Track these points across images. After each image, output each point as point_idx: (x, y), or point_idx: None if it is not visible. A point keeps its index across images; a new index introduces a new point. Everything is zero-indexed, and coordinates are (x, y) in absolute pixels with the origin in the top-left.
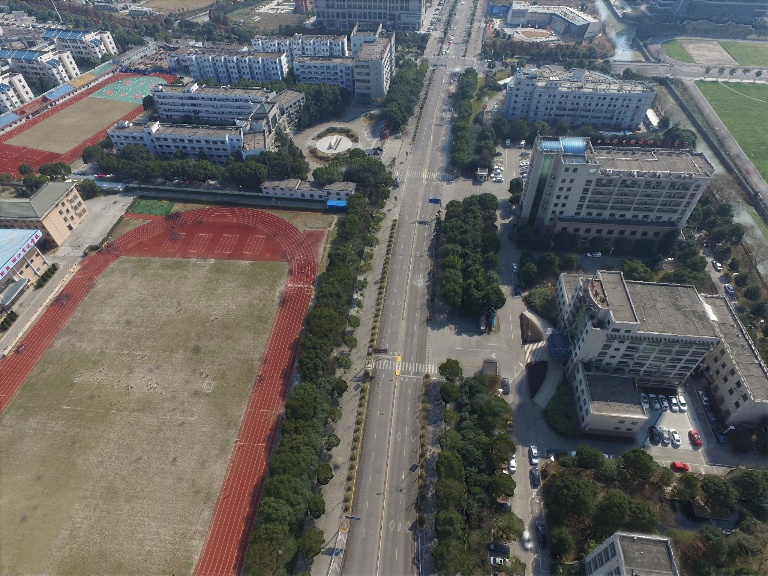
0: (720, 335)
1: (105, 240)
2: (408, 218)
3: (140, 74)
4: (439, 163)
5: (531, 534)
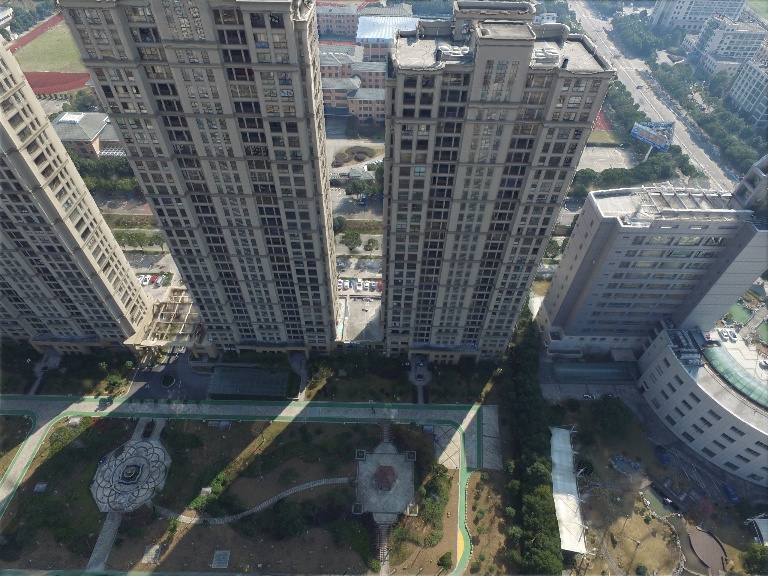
0: (763, 46)
1: None
2: (589, 30)
3: None
4: (589, 12)
5: (703, 98)
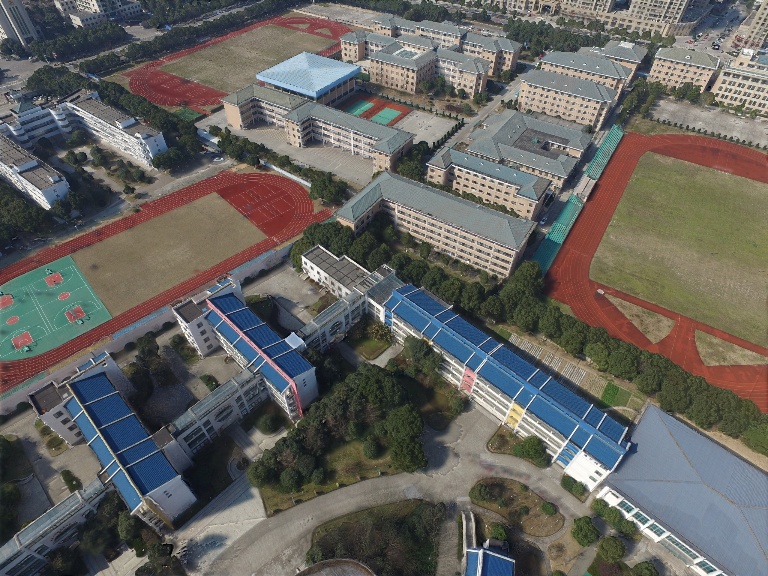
0: None
1: None
2: None
3: None
4: None
5: None
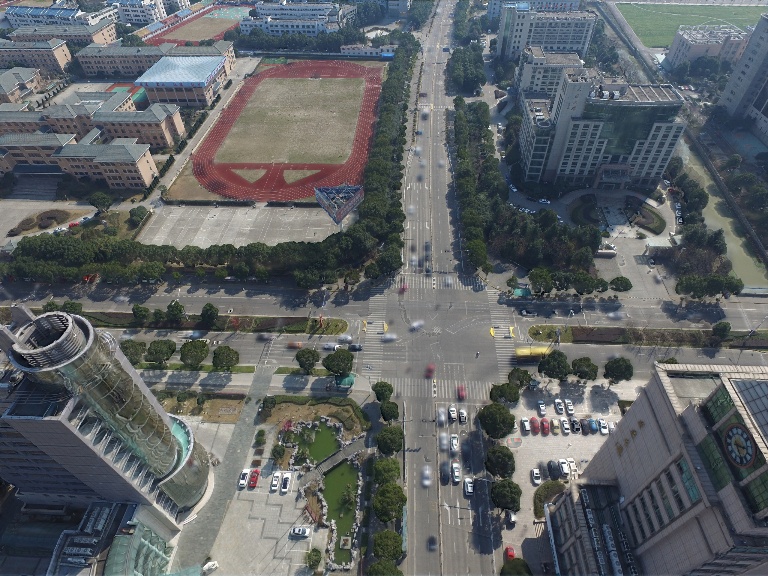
0: None
1: (254, 72)
2: (430, 62)
3: (233, 5)
4: (447, 41)
5: (497, 143)
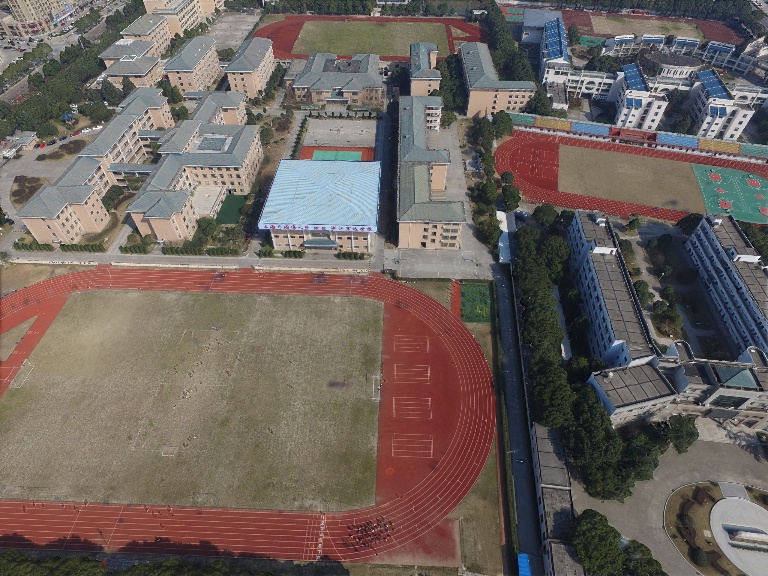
0: None
1: (408, 280)
2: None
3: None
4: None
5: None
